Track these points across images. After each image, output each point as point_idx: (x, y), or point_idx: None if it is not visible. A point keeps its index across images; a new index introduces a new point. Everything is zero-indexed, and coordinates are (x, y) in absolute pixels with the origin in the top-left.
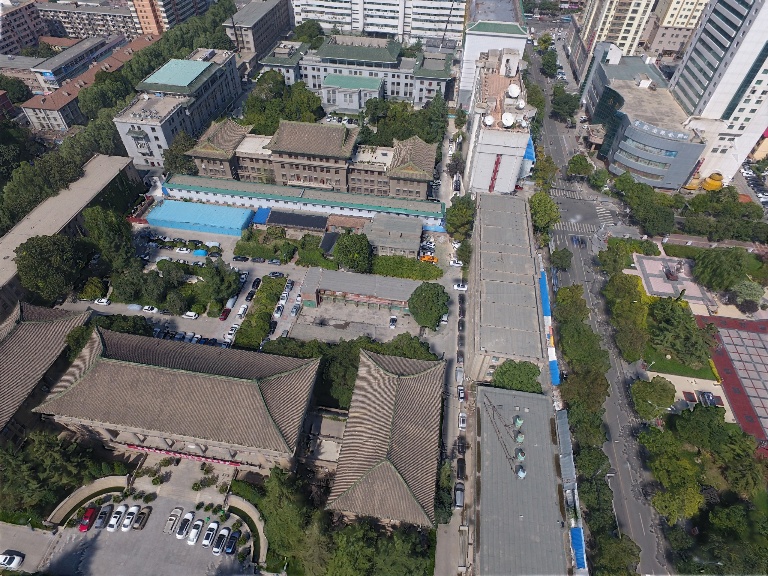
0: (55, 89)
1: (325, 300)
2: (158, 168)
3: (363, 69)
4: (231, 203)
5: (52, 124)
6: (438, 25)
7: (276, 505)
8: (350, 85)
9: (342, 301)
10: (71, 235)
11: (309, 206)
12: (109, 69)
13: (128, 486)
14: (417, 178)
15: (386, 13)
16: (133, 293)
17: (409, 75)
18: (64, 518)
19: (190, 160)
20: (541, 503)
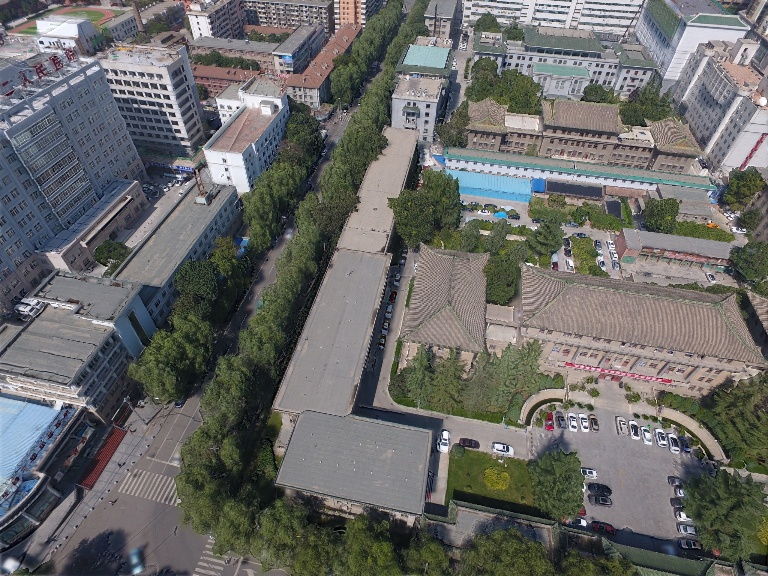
0: (287, 71)
1: (637, 258)
2: (424, 142)
3: (569, 58)
4: (504, 174)
5: (306, 102)
6: (607, 20)
7: (759, 406)
8: (560, 73)
9: (654, 259)
10: None
11: (582, 177)
12: (338, 54)
13: (565, 398)
14: (690, 153)
15: (556, 8)
16: (475, 245)
17: (613, 65)
18: (526, 420)
19: (463, 134)
20: None
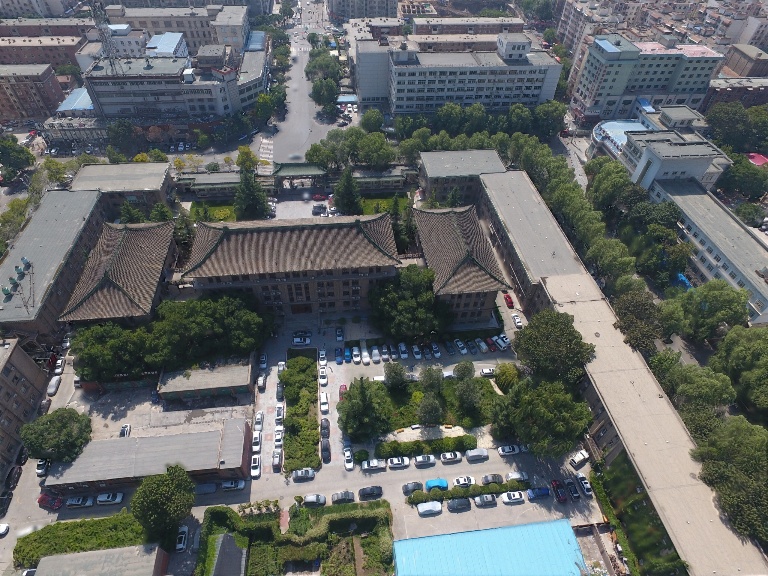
0: None
1: None
2: None
3: None
4: None
5: None
6: None
7: None
8: None
9: None
10: (597, 411)
11: None
12: None
13: None
14: None
15: None
16: None
17: None
18: None
19: None
20: (21, 255)
